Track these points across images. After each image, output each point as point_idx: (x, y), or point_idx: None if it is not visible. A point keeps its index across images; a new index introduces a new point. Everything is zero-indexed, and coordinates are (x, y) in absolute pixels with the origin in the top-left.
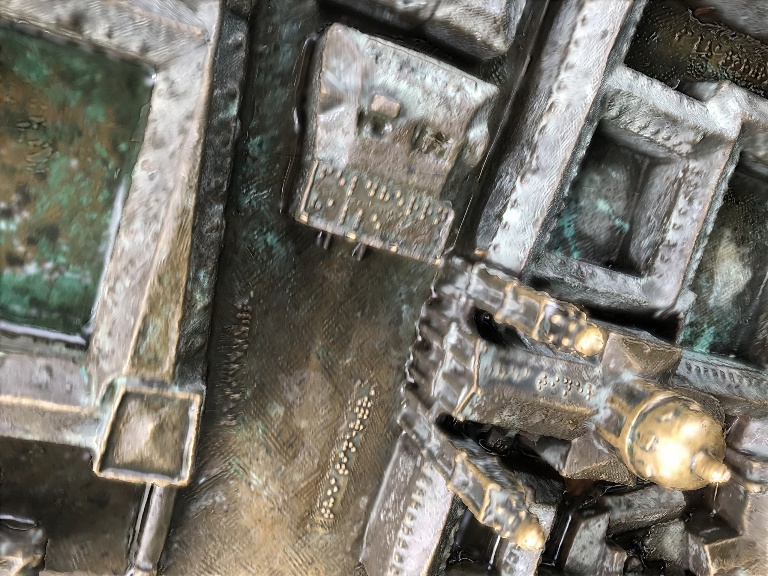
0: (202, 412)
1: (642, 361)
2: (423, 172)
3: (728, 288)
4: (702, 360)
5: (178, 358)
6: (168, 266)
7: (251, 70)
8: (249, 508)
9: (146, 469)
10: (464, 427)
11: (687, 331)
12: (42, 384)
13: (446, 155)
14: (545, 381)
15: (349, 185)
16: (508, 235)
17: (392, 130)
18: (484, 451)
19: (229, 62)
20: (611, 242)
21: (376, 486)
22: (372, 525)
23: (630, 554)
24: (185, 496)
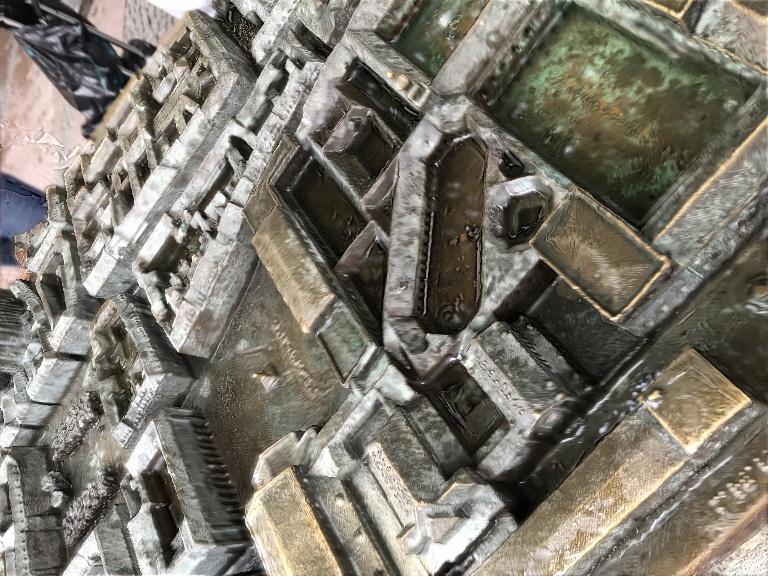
0: None
1: None
2: None
3: None
4: None
5: None
6: None
7: None
8: None
9: None
10: None
11: None
12: None
13: None
14: None
15: None
16: None
17: None
18: None
19: None
20: None
21: None
22: None
23: None
24: None
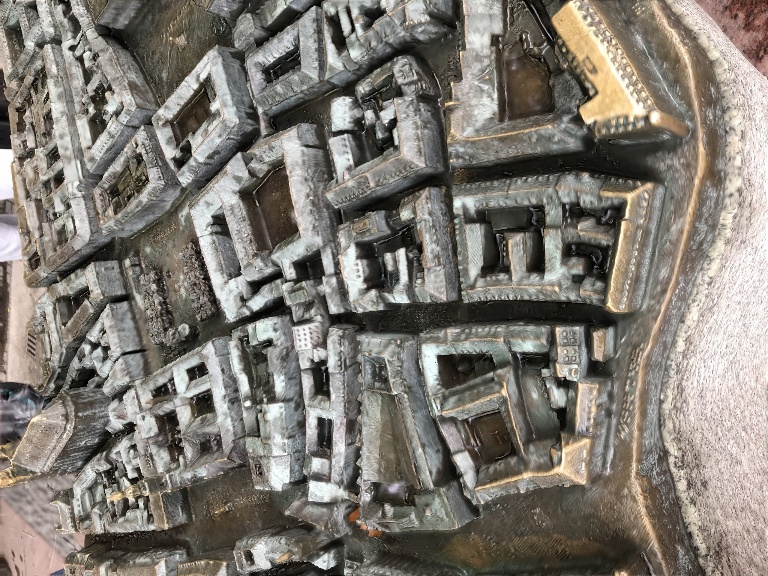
0: None
1: None
2: None
3: None
4: None
5: None
6: None
7: None
8: None
9: None
10: None
11: None
12: None
13: None
14: None
15: None
16: None
17: None
18: None
19: None
20: None
21: None
22: None
23: None
24: None
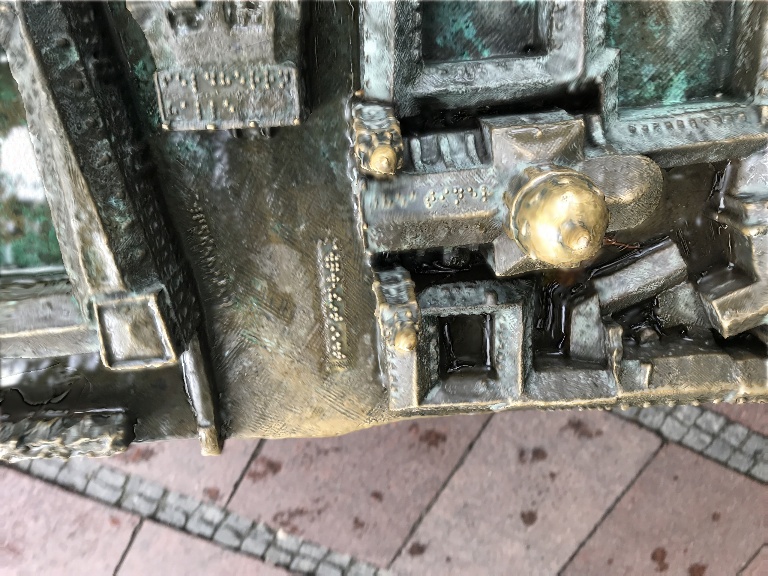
0: (171, 305)
1: (533, 147)
2: (250, 45)
3: (689, 22)
4: (657, 115)
5: (122, 271)
6: (78, 204)
7: (103, 7)
8: (273, 365)
9: (141, 357)
10: (400, 257)
11: (650, 87)
12: (47, 316)
13: (263, 20)
14: (434, 197)
15: (191, 83)
16: (373, 68)
17: (204, 18)
18: (408, 274)
19: (46, 19)
20: (522, 25)
21: (372, 324)
22: (381, 356)
23: (643, 326)
24: (219, 368)
